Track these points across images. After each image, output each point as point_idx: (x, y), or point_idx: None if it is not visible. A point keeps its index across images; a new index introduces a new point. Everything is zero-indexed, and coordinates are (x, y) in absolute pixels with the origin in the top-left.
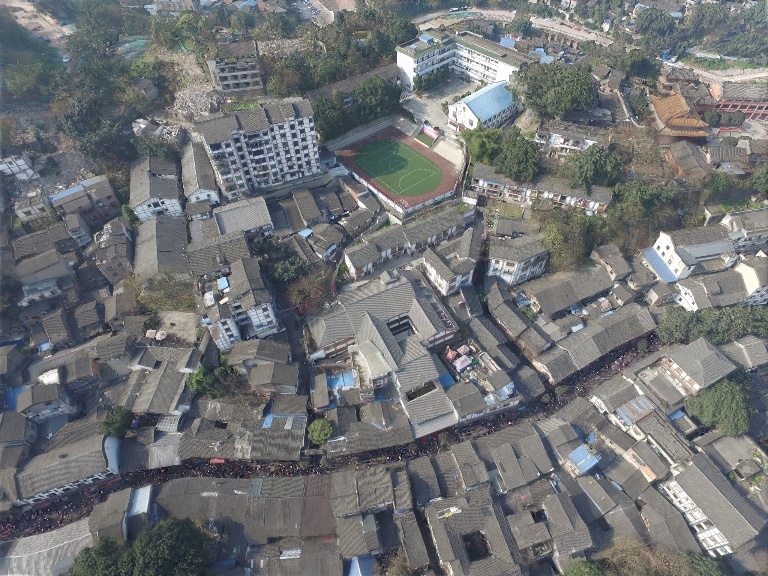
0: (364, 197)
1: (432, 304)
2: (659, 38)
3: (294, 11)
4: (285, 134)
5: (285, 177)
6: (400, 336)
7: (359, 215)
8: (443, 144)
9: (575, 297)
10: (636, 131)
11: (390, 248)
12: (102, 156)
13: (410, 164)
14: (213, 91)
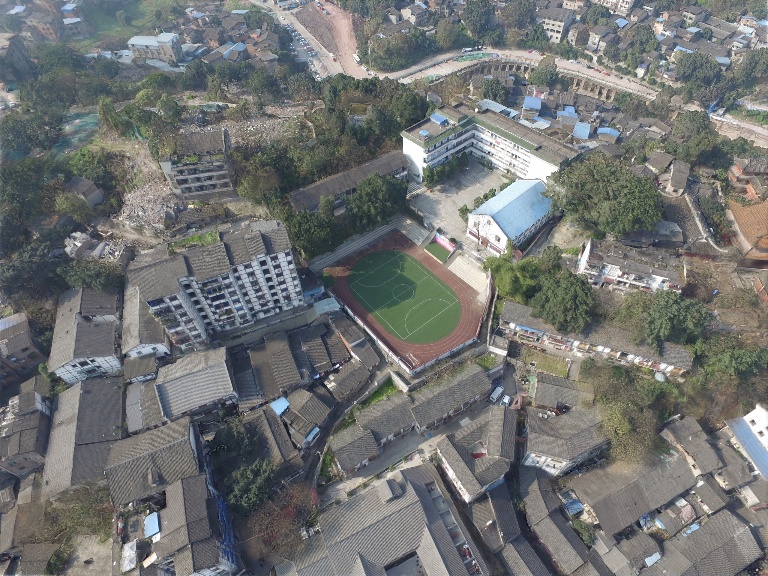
0: (359, 347)
1: (450, 530)
2: (704, 88)
3: (288, 55)
4: (254, 272)
5: (257, 315)
6: (405, 567)
7: (352, 373)
8: (461, 261)
9: (646, 505)
10: (715, 255)
11: (392, 432)
12: (21, 290)
13: (419, 290)
14: (170, 194)
